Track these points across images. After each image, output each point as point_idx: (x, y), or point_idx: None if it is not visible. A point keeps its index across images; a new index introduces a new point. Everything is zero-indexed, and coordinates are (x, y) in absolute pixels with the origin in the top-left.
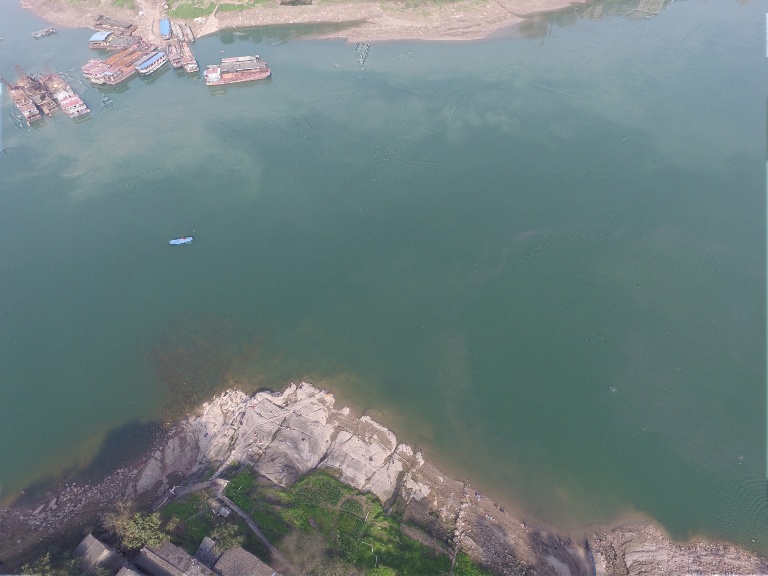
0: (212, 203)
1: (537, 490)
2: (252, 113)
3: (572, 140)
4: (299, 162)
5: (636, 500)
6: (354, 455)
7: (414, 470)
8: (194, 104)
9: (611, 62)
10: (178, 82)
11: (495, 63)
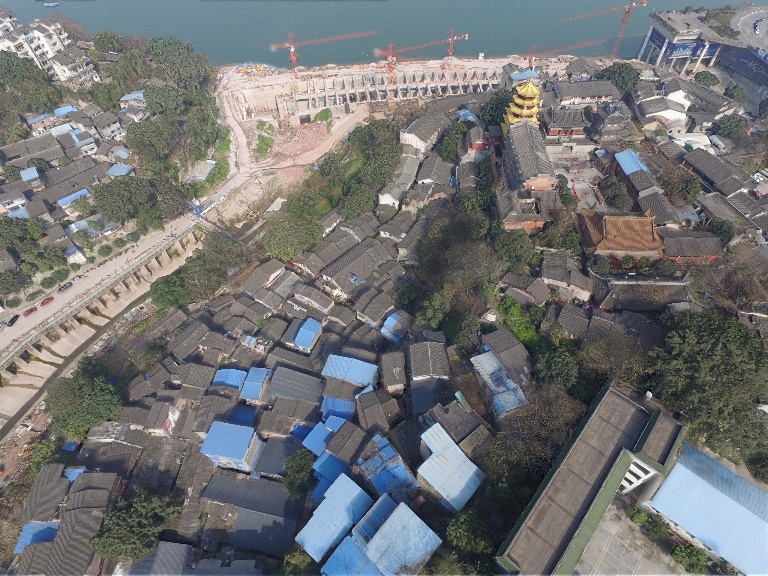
0: None
1: None
2: None
3: None
4: None
5: (240, 61)
6: None
7: None
8: None
9: None
10: None
11: None
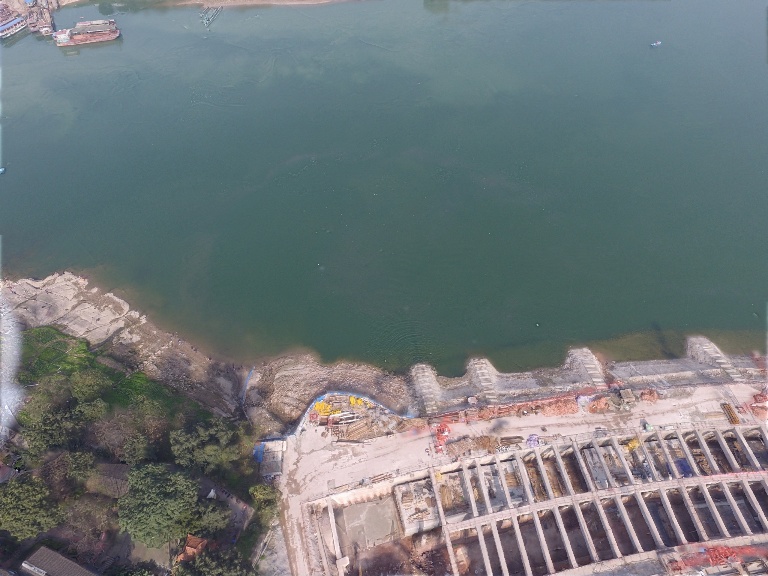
0: (31, 142)
1: (231, 336)
2: (94, 69)
3: (375, 85)
4: (123, 108)
5: (307, 340)
6: (85, 317)
7: (133, 327)
8: (41, 62)
9: (435, 21)
10: (32, 44)
11: (332, 23)
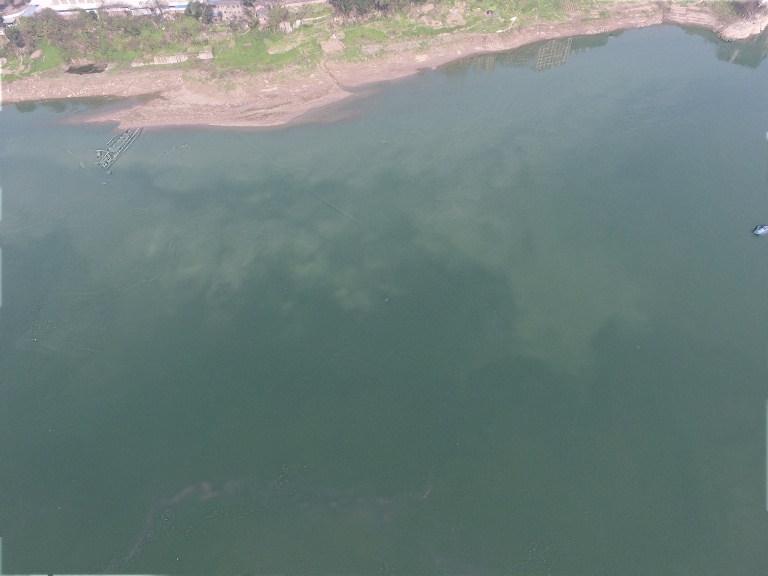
0: None
1: None
2: None
3: (319, 299)
4: None
5: None
6: None
7: None
8: None
9: (427, 163)
10: None
11: (282, 163)
